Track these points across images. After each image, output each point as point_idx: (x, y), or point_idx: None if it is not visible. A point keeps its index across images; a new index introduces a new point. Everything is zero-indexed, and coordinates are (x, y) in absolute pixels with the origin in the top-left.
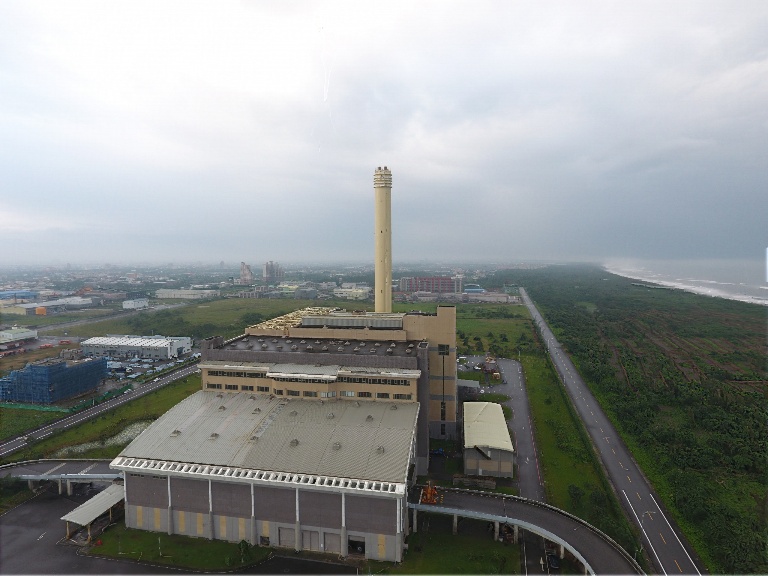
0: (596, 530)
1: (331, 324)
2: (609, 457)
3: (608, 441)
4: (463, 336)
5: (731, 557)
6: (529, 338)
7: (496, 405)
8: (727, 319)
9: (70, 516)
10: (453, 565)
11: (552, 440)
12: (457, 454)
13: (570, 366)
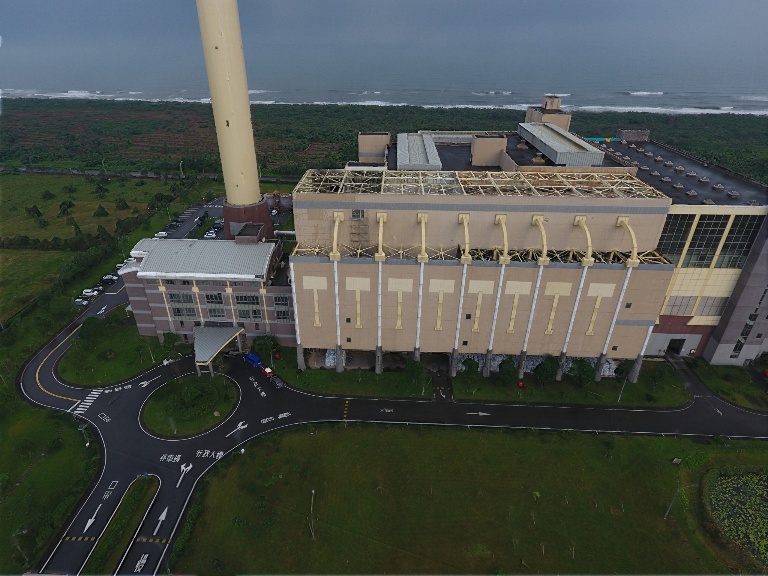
0: None
1: None
2: None
3: None
4: (38, 211)
5: None
6: (97, 179)
7: None
8: (88, 115)
9: None
10: None
11: None
12: None
13: (265, 178)
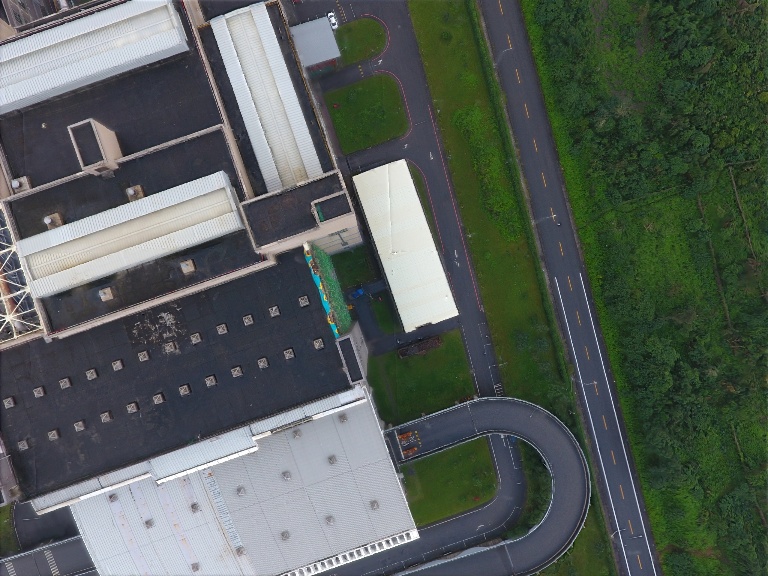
0: (547, 412)
1: (104, 276)
2: (540, 200)
3: (537, 149)
4: None
5: (637, 382)
6: None
7: (401, 170)
8: None
9: None
10: (444, 478)
11: (474, 188)
12: (379, 284)
13: None
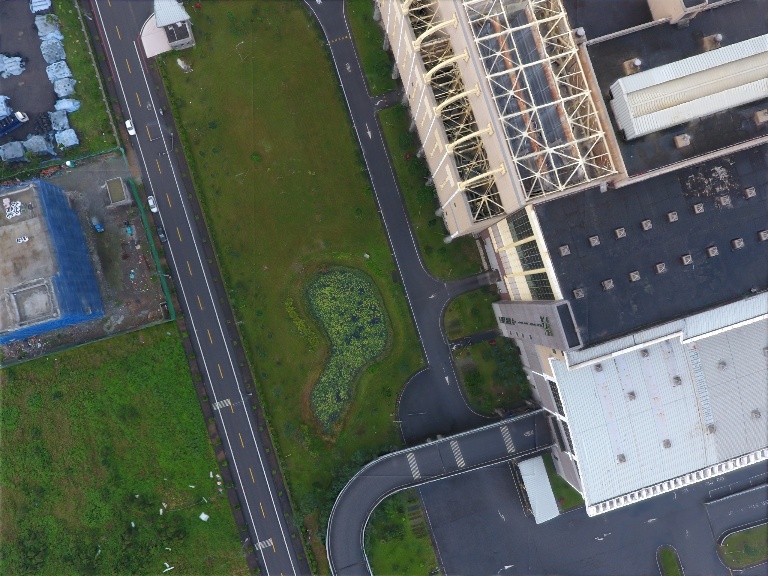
0: None
1: (690, 120)
2: None
3: None
4: None
5: None
6: None
7: None
8: None
9: (541, 518)
10: None
11: None
12: None
13: None
